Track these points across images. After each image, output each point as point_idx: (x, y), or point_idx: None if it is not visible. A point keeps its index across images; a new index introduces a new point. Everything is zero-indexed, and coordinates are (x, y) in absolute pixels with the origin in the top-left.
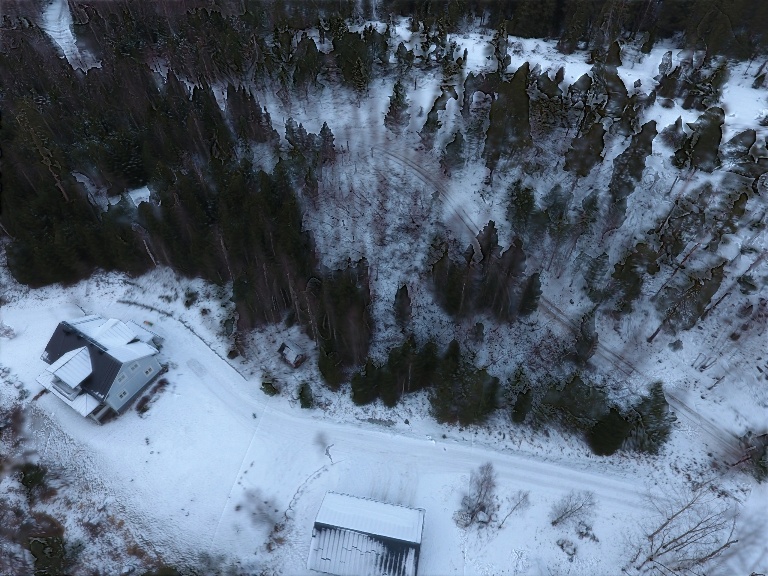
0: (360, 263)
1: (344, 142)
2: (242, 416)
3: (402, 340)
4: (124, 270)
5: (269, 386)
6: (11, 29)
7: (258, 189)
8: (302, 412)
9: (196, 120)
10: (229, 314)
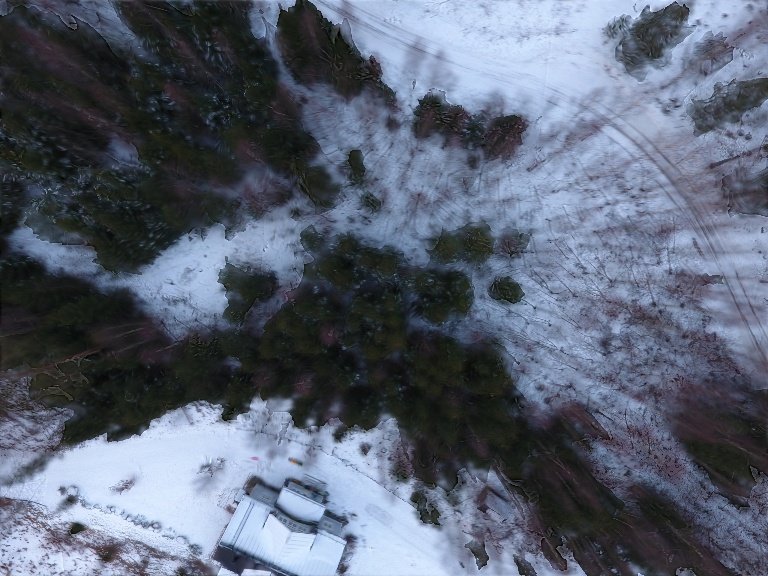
0: (592, 427)
1: (521, 90)
2: (449, 567)
3: (625, 483)
4: None
5: (484, 565)
6: None
7: (410, 293)
8: (512, 558)
9: (251, 153)
10: (397, 448)
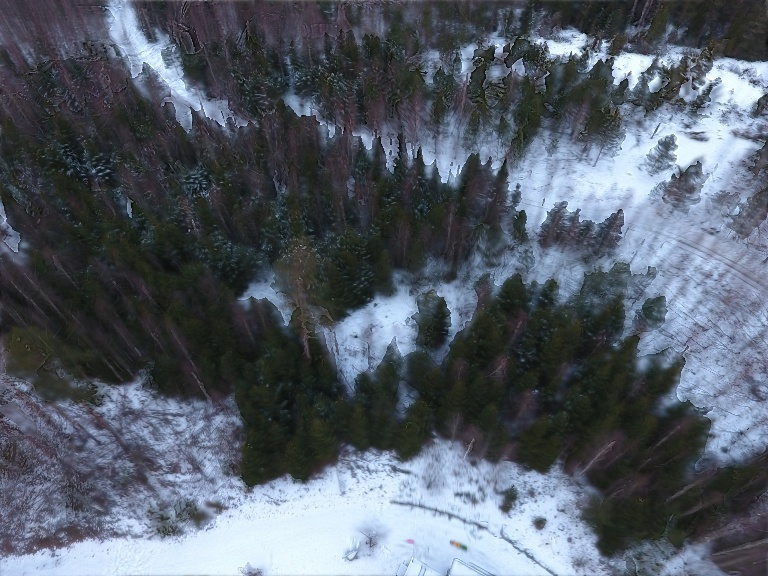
0: None
1: None
2: None
3: None
4: (387, 448)
5: None
6: (94, 60)
7: None
8: None
9: (452, 216)
10: (576, 525)
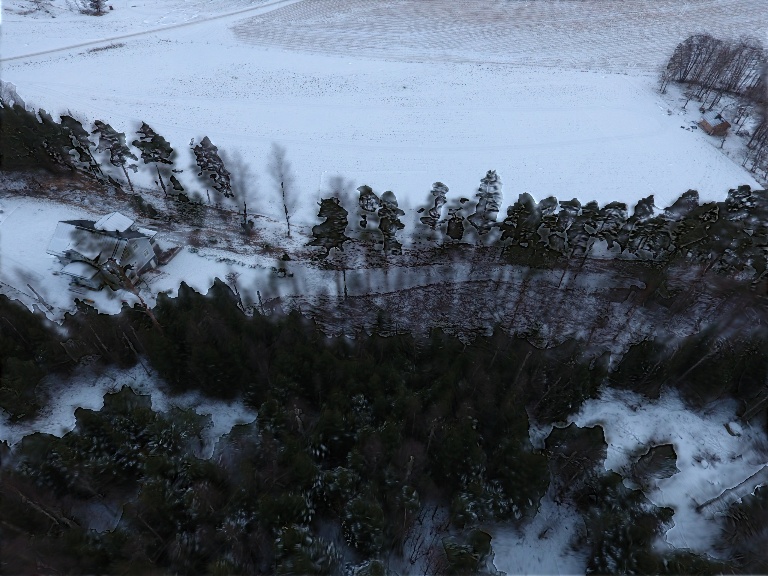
0: None
1: None
2: None
3: None
4: None
5: None
6: None
7: None
8: None
9: None
10: None
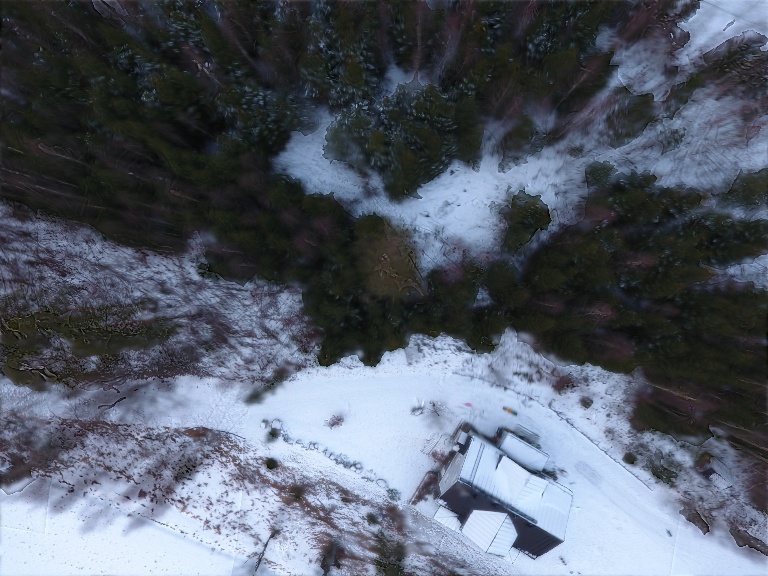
0: None
1: None
2: (656, 534)
3: None
4: None
5: None
6: None
7: None
8: (722, 531)
9: (586, 75)
10: (618, 405)
